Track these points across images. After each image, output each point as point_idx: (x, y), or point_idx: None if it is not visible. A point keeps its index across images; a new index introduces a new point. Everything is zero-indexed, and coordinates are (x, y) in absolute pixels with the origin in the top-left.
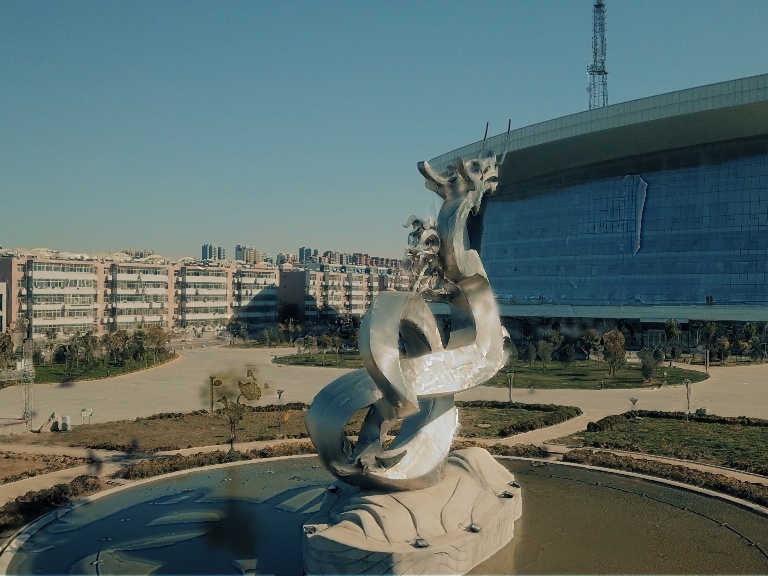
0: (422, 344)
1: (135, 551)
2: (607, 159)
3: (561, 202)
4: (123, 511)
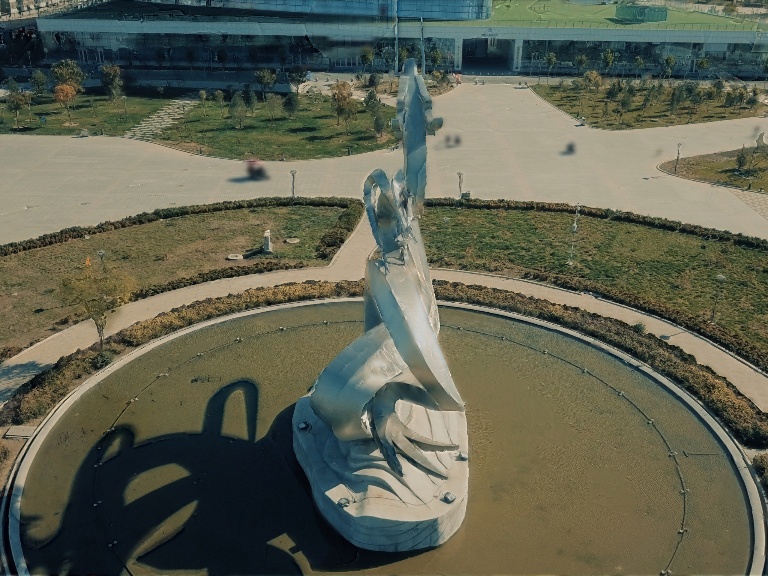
0: None
1: (156, 552)
2: None
3: None
4: (76, 486)
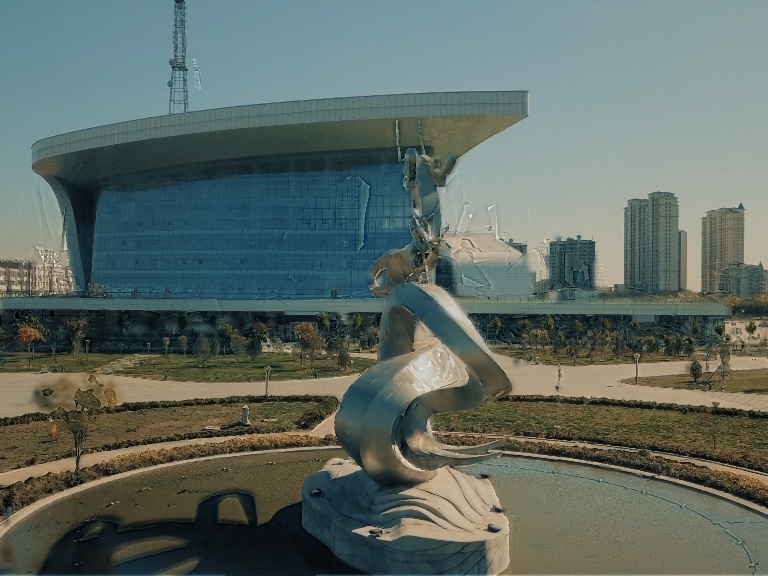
0: (405, 336)
1: None
2: (237, 157)
3: (187, 196)
4: (51, 555)
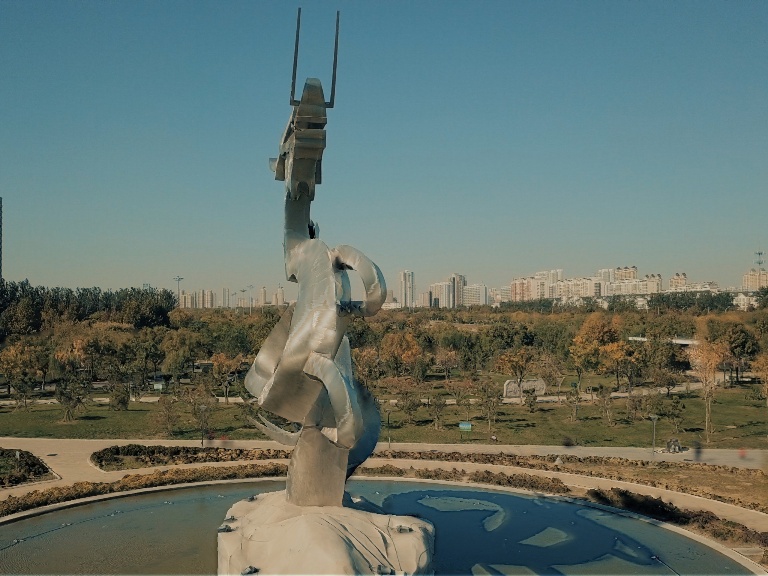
0: None
1: None
2: None
3: None
4: (614, 531)
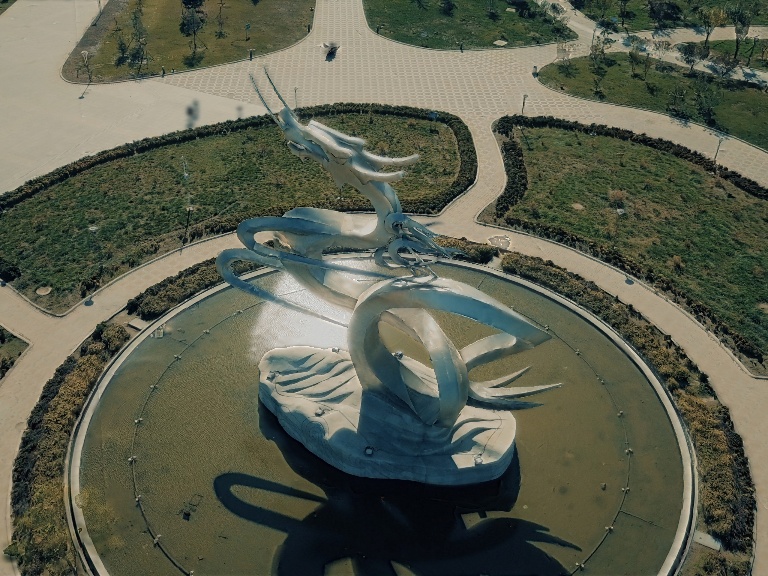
0: None
1: None
2: None
3: None
4: None
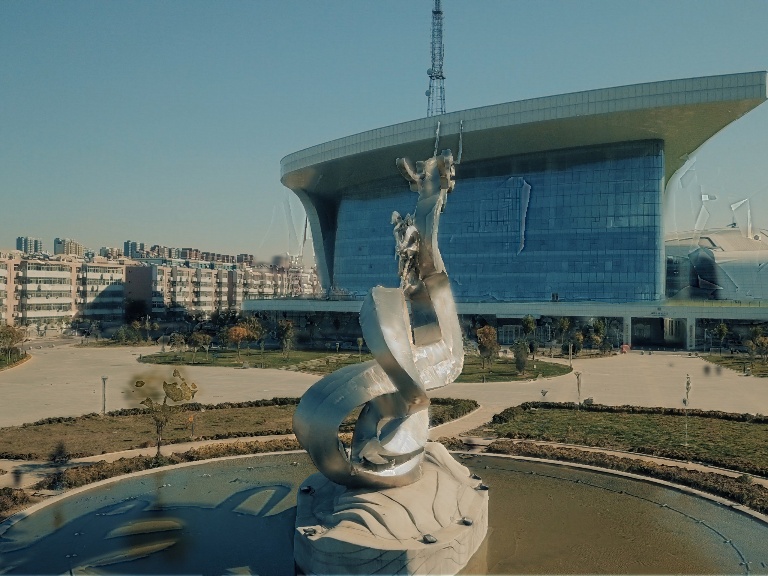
0: None
1: (109, 566)
2: (461, 161)
3: (415, 201)
4: (70, 524)
